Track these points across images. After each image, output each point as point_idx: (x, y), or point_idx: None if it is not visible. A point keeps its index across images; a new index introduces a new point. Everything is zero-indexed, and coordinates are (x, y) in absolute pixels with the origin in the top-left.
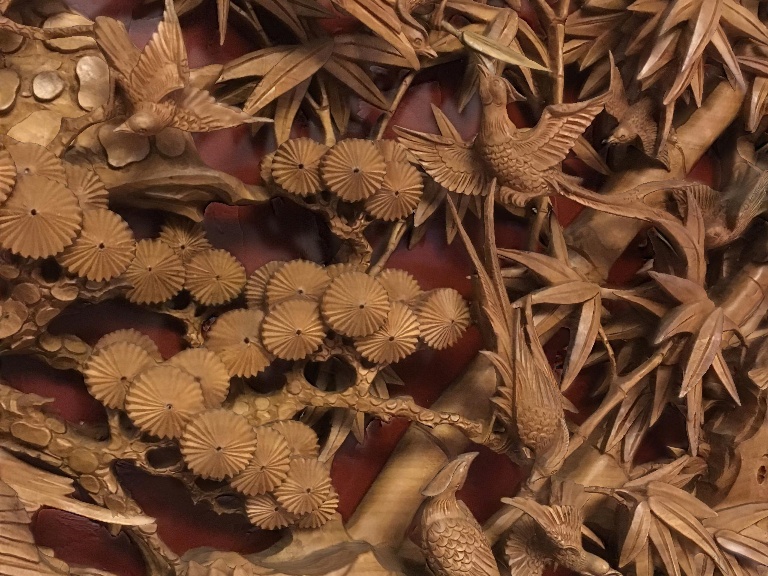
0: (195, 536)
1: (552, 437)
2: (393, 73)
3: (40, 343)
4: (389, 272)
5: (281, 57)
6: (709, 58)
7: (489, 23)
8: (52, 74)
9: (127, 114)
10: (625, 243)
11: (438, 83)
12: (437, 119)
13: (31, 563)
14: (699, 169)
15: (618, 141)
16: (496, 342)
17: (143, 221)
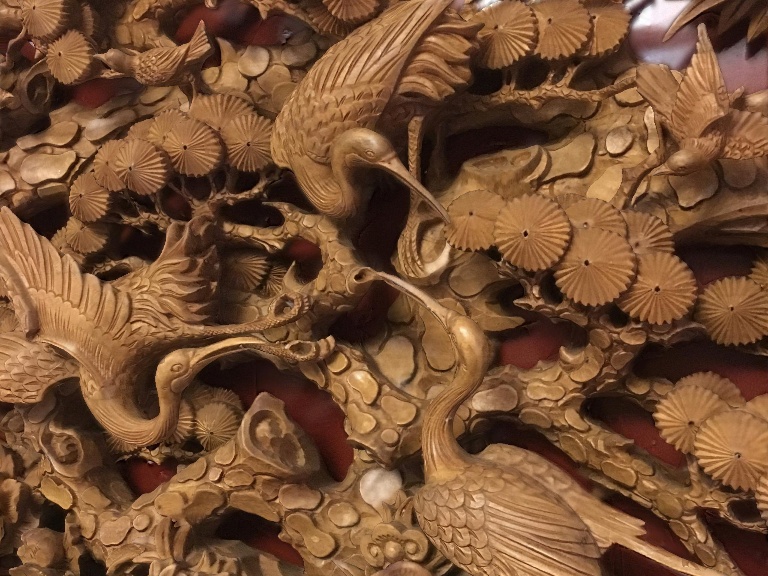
0: None
1: None
2: None
3: (627, 386)
4: None
5: None
6: None
7: None
8: (622, 129)
9: None
10: None
11: None
12: None
13: None
14: None
15: None
16: None
17: (733, 258)
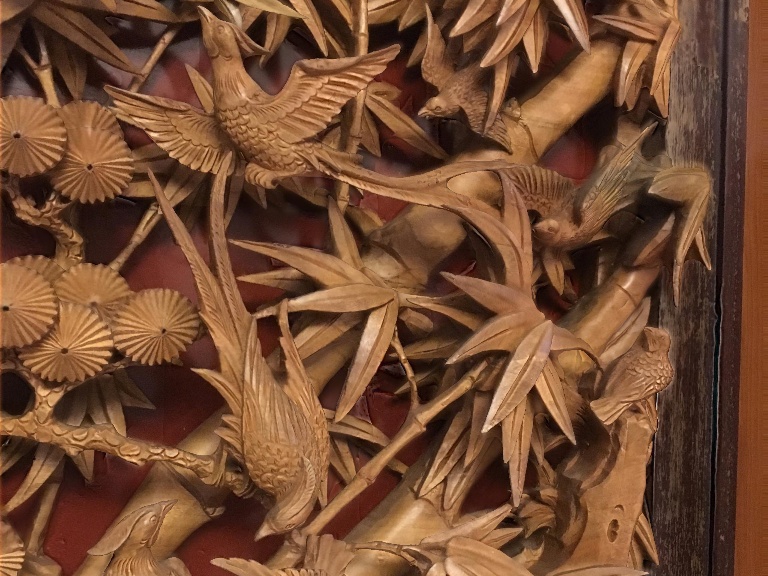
0: None
1: (294, 480)
2: (140, 27)
3: None
4: (81, 267)
5: None
6: (551, 13)
7: None
8: None
9: None
10: (453, 240)
11: (198, 40)
12: (194, 83)
13: None
14: (555, 152)
15: (433, 114)
16: (218, 358)
17: None
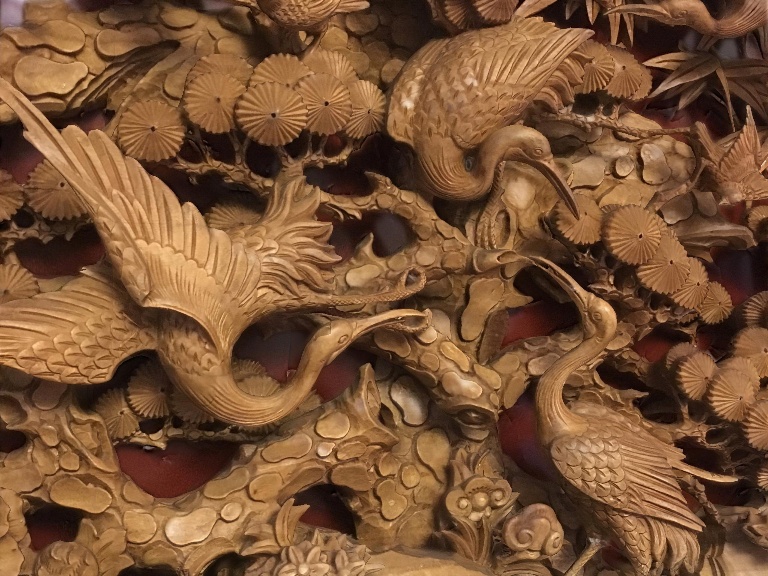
0: (709, 496)
1: None
2: None
3: None
4: None
5: (760, 137)
6: None
7: None
8: (627, 158)
9: (702, 189)
10: None
11: None
12: None
13: (684, 505)
14: None
15: None
16: None
17: None
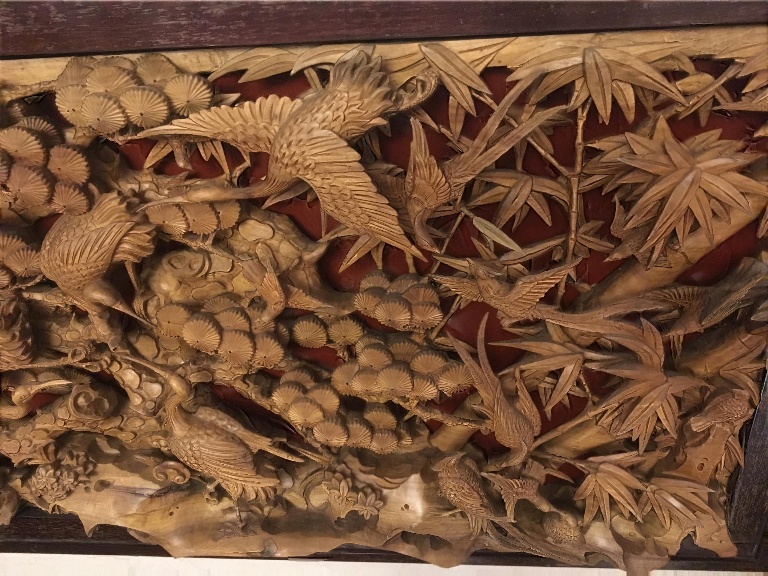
0: None
1: (518, 447)
2: (447, 216)
3: None
4: (422, 356)
5: None
6: None
7: (510, 188)
8: (245, 254)
9: None
10: (628, 311)
11: None
12: (476, 246)
13: (253, 476)
14: (706, 261)
15: None
16: (482, 400)
17: None
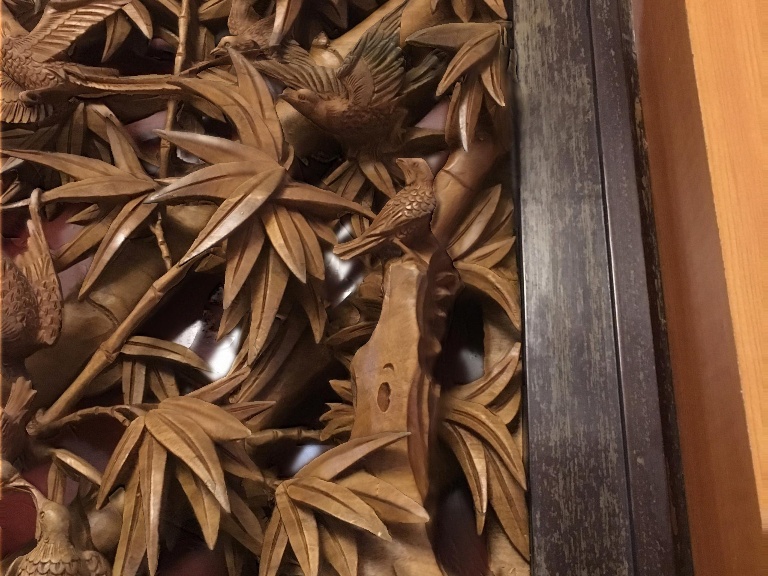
0: None
1: None
2: None
3: None
4: None
5: None
6: None
7: None
8: None
9: None
10: None
11: None
12: None
13: None
14: None
15: (225, 51)
16: None
17: None
